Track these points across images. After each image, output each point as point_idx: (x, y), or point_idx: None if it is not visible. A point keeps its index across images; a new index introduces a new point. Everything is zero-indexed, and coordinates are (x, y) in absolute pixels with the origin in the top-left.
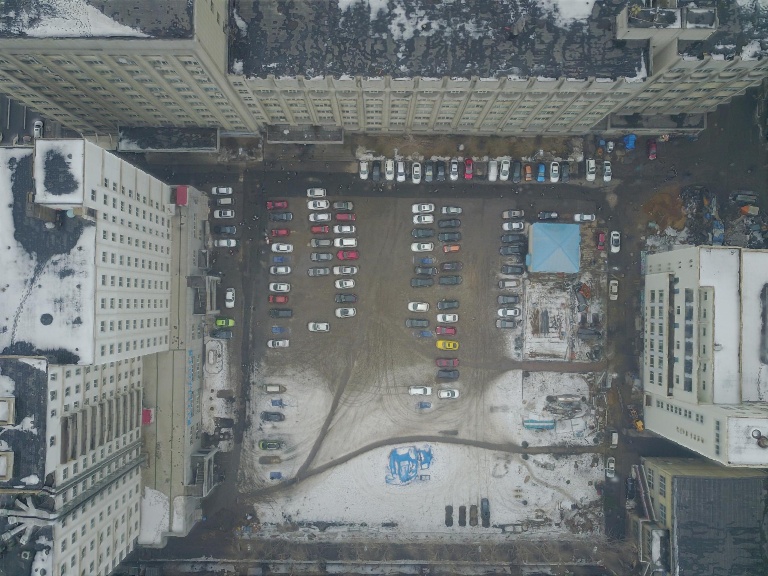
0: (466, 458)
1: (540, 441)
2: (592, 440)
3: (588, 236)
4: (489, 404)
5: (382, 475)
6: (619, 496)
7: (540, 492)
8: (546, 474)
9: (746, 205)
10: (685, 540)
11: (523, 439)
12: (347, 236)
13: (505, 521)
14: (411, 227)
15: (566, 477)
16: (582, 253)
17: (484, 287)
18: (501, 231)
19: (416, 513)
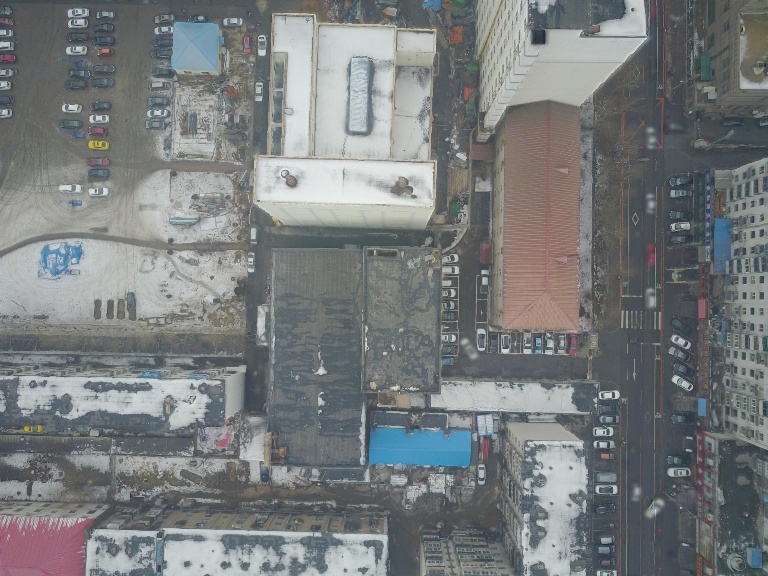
0: (115, 254)
1: (186, 238)
2: (236, 237)
3: (237, 41)
4: (138, 202)
5: (35, 270)
6: (260, 291)
7: (183, 286)
8: (191, 270)
9: (386, 7)
10: (281, 311)
11: (170, 236)
12: (6, 41)
13: (151, 314)
14: (68, 32)
15: (210, 273)
16: (231, 57)
17: (136, 90)
18: (154, 36)
19: (66, 306)
